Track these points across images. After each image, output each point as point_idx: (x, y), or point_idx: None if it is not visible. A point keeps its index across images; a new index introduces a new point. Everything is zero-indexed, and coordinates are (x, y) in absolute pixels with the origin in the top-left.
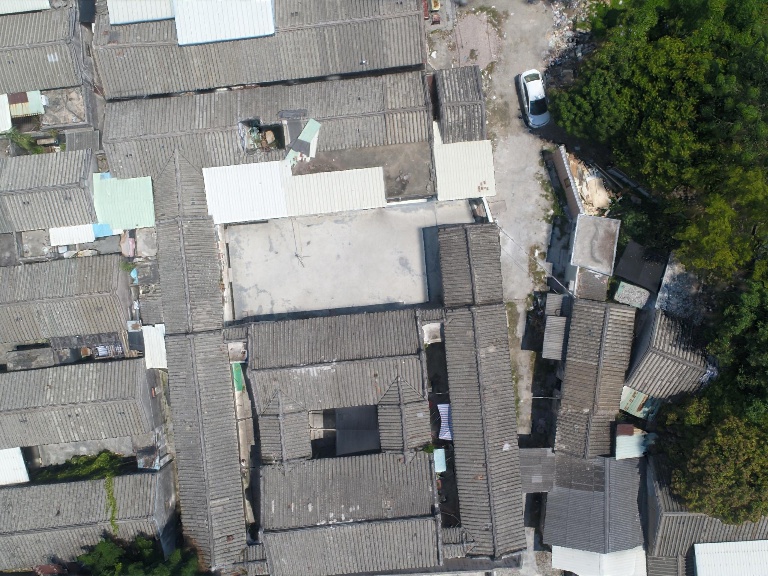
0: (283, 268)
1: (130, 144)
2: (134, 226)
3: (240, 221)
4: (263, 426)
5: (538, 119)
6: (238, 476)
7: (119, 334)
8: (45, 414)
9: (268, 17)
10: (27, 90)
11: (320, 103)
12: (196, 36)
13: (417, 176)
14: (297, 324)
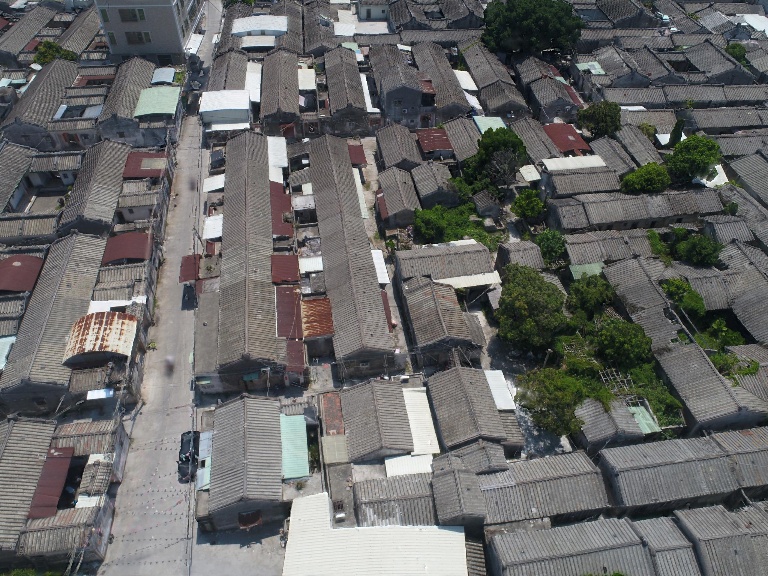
0: None
1: None
2: None
3: None
4: (435, 27)
5: None
6: None
7: None
8: None
9: None
10: None
11: None
12: None
13: (341, 6)
14: None
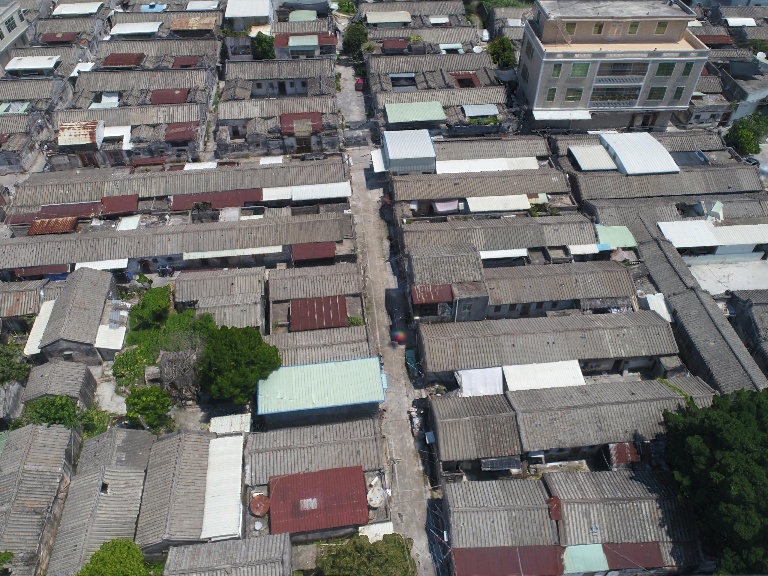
0: (713, 288)
1: (611, 210)
2: (623, 246)
3: (690, 247)
4: (767, 347)
5: None
6: (765, 379)
7: (630, 299)
8: (600, 332)
9: (675, 165)
10: (539, 192)
11: (715, 199)
12: (637, 171)
13: None
14: (760, 290)
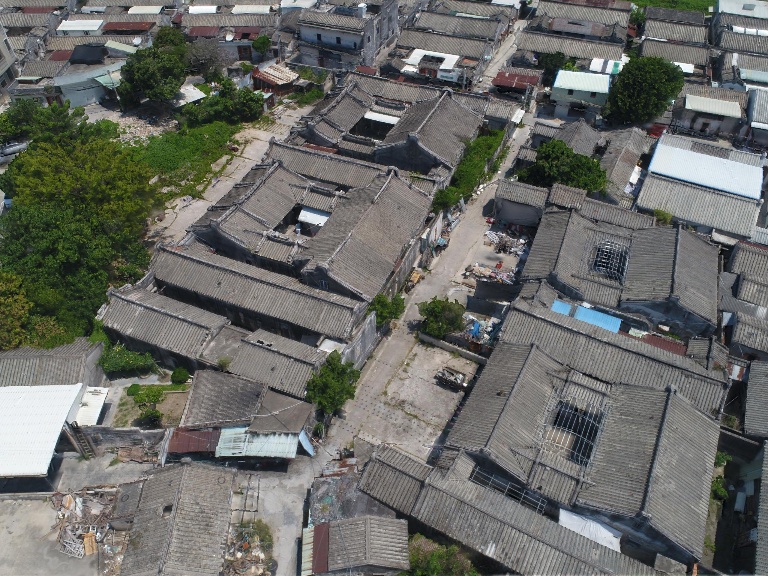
0: None
1: None
2: None
3: None
4: None
5: (8, 201)
6: None
7: None
8: None
9: None
10: None
11: None
12: None
13: None
14: None
